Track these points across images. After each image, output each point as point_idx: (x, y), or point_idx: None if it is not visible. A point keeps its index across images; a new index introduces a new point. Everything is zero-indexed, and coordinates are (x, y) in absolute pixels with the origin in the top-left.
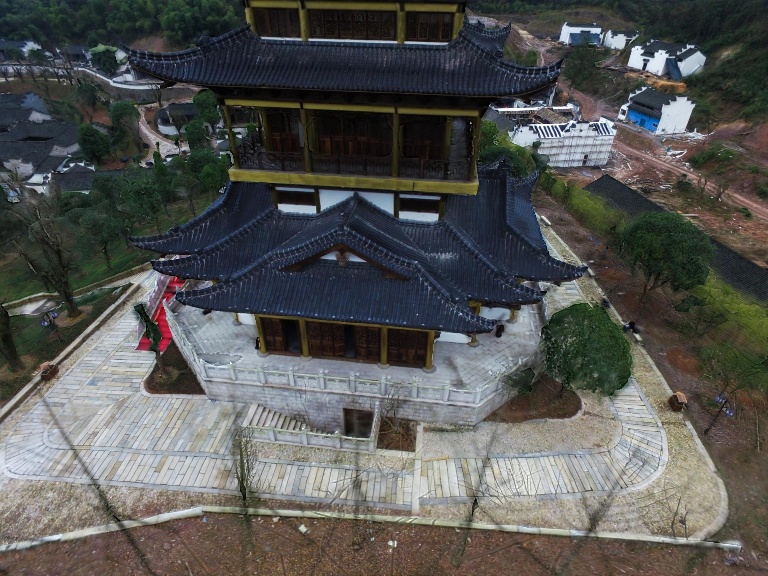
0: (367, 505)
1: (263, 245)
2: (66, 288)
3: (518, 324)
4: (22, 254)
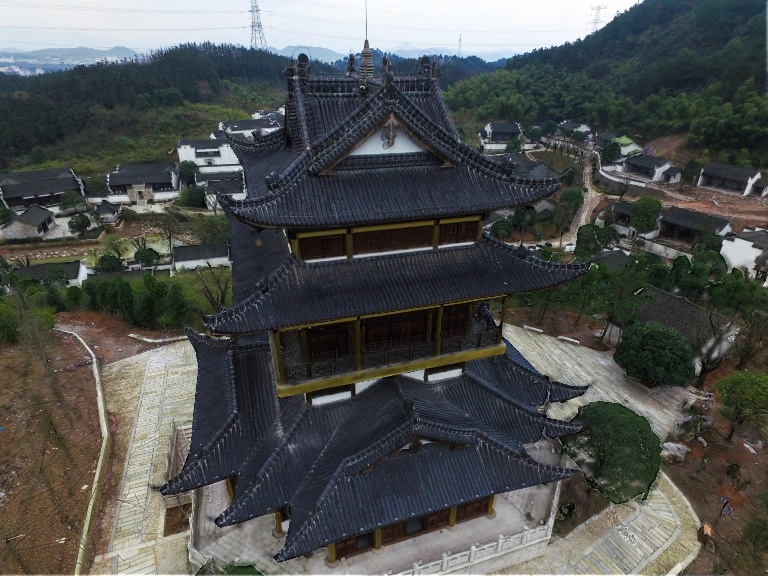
0: (114, 522)
1: (265, 334)
2: None
3: (326, 570)
4: None
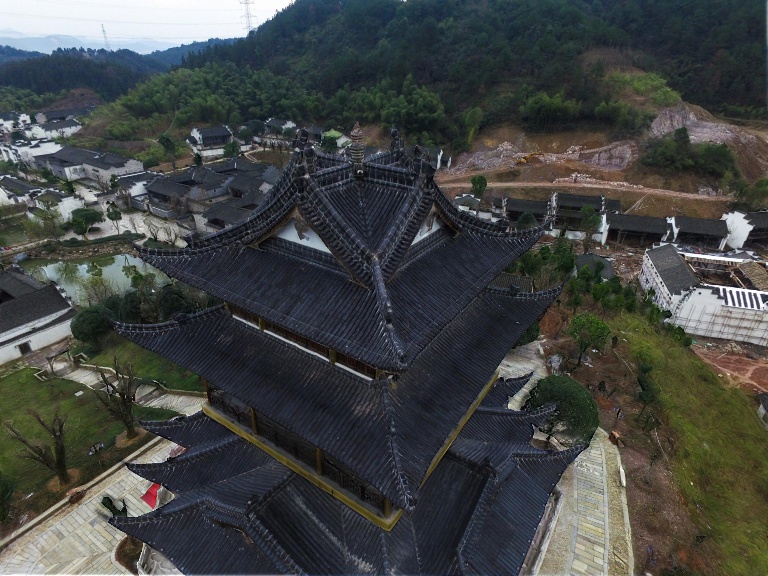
0: None
1: (225, 469)
2: (126, 418)
3: None
4: (95, 393)
